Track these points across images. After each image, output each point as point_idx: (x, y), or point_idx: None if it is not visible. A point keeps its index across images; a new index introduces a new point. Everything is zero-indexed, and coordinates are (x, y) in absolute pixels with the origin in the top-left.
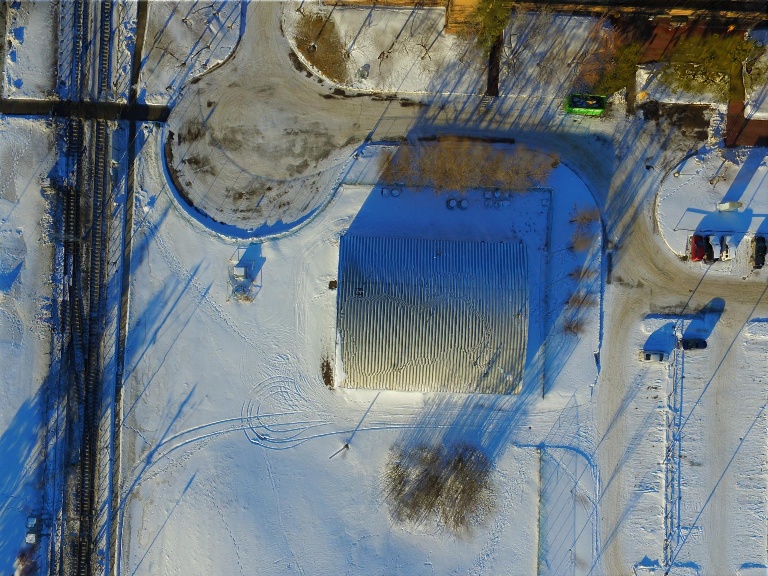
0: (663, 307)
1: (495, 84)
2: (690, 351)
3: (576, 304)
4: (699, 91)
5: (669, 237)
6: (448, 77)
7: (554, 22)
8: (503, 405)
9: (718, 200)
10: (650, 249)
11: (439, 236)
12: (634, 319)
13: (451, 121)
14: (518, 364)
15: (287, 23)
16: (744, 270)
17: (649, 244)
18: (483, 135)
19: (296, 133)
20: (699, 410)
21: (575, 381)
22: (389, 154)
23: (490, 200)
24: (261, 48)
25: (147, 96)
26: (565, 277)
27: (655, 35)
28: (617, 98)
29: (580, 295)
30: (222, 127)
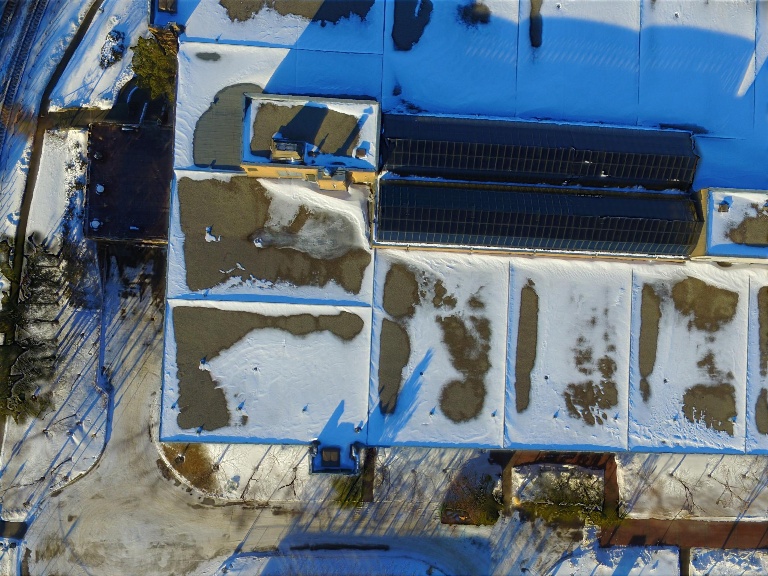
0: None
1: (370, 490)
2: None
3: None
4: (571, 502)
5: None
6: (321, 485)
7: None
8: None
9: None
10: None
11: None
12: None
13: (324, 528)
14: None
15: (155, 428)
16: None
17: None
18: (357, 542)
19: (162, 546)
20: None
21: None
22: (259, 566)
23: None
24: (127, 455)
25: (3, 512)
26: None
27: None
28: None
29: None
30: (83, 542)
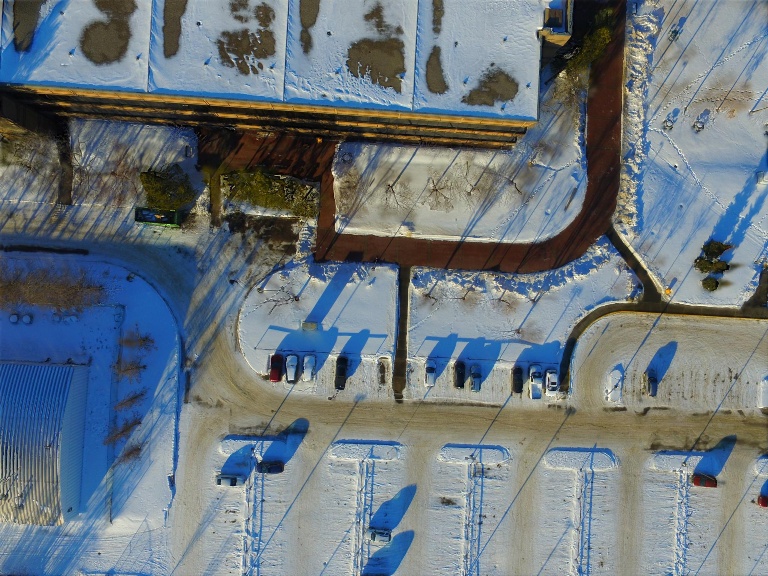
0: (243, 428)
1: (68, 192)
2: (268, 474)
3: (149, 425)
4: (276, 206)
5: (249, 355)
6: (15, 184)
7: (125, 130)
8: (69, 530)
9: (303, 317)
10: (231, 367)
11: (1, 352)
12: (212, 440)
13: (20, 230)
14: (53, 497)
15: None
16: (330, 390)
17: (230, 362)
18: (54, 245)
19: None
20: (280, 534)
21: (146, 505)
22: None
23: (55, 315)
24: None
25: None
26: (136, 397)
27: (242, 144)
28: (200, 209)
29: (154, 415)
30: None
